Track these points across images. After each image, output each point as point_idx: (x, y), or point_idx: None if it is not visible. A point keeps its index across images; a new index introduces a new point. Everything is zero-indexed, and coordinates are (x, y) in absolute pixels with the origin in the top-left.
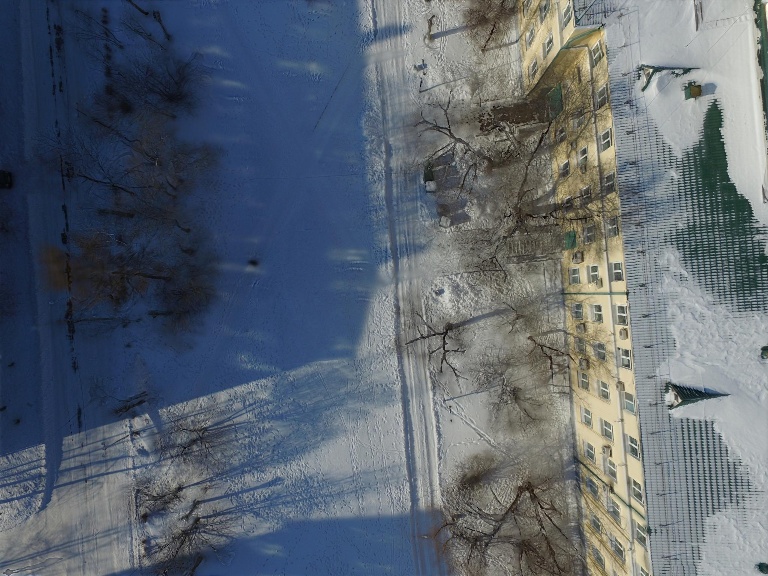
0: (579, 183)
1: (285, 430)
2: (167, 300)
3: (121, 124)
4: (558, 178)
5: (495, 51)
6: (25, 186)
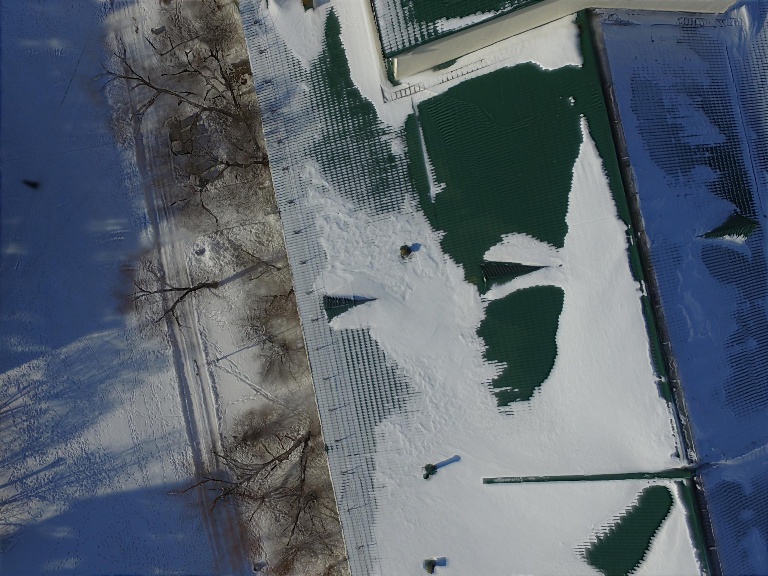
0: None
1: (62, 409)
2: None
3: None
4: None
5: (231, 6)
6: None
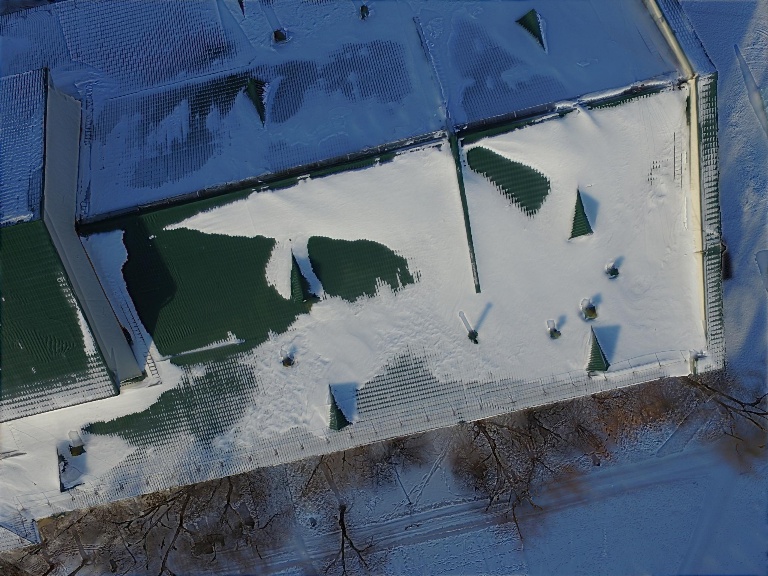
0: None
1: None
2: None
3: None
4: None
5: None
6: None
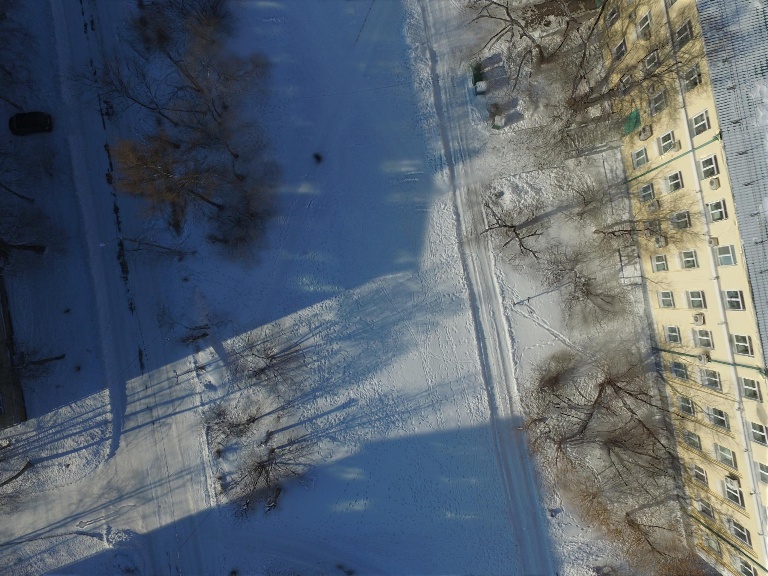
0: (641, 54)
1: (354, 350)
2: (222, 229)
3: (159, 55)
4: (611, 64)
5: None
6: (65, 128)
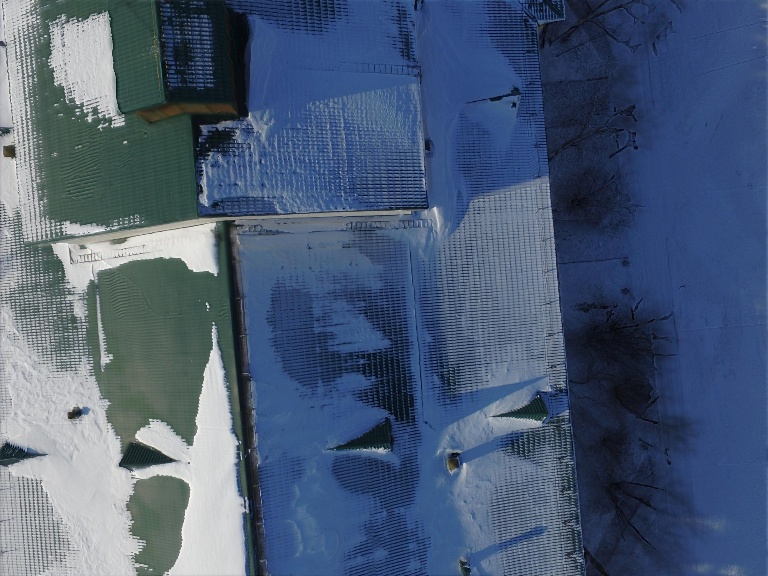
0: None
1: None
2: None
3: None
4: None
5: None
6: None
